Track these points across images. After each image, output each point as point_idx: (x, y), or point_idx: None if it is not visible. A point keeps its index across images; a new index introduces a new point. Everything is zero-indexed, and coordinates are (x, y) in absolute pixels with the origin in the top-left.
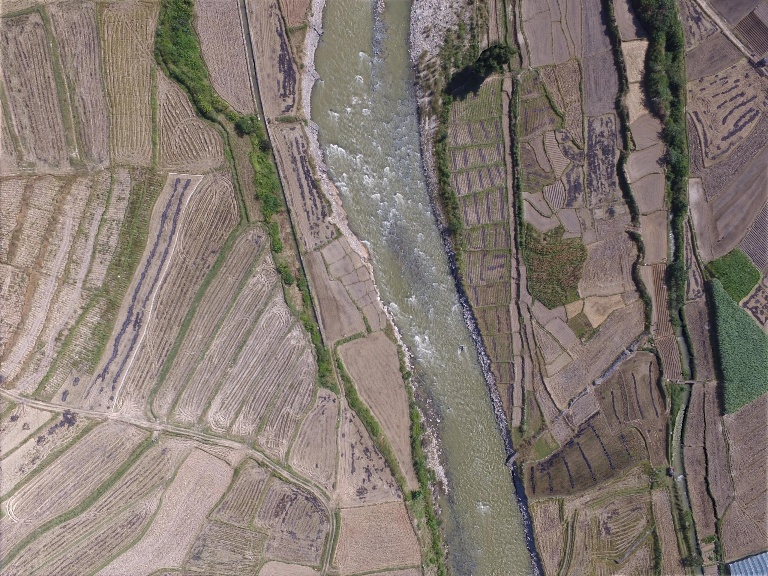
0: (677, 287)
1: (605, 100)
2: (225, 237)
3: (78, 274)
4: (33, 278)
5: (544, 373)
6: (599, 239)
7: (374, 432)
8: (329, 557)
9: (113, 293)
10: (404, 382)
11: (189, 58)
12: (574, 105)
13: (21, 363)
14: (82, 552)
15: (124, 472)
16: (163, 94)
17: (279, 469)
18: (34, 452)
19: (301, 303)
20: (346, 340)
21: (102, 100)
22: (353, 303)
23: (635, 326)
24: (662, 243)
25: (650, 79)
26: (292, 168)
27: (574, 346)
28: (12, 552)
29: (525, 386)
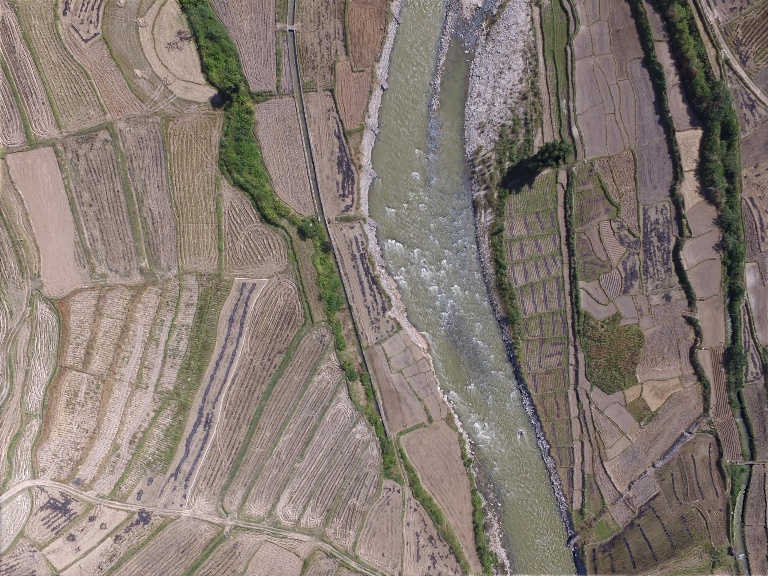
0: (736, 371)
1: (660, 188)
2: (290, 338)
3: (150, 379)
4: (107, 385)
5: (604, 457)
6: (656, 324)
7: (439, 521)
8: None
9: (184, 396)
10: (466, 469)
11: (252, 167)
12: (629, 194)
13: (97, 466)
14: None
15: (198, 567)
16: (228, 202)
17: (347, 559)
18: (111, 550)
19: (364, 397)
20: (408, 431)
21: (169, 210)
22: (414, 394)
23: (694, 408)
24: (719, 327)
25: (706, 168)
26: (352, 266)
27: (633, 430)
28: None
29: (585, 470)
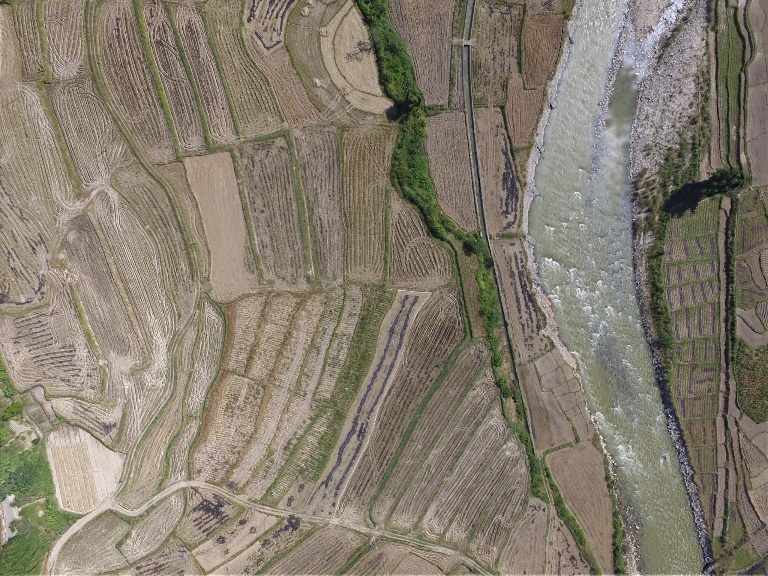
0: None
1: None
2: (449, 352)
3: (308, 386)
4: (268, 390)
5: (749, 486)
6: None
7: (582, 542)
8: None
9: (340, 404)
10: (609, 491)
11: (424, 180)
12: None
13: (252, 470)
14: None
15: (342, 575)
16: (396, 214)
17: (489, 575)
18: (259, 554)
19: (516, 414)
20: (555, 450)
21: (338, 220)
22: (563, 414)
23: None
24: None
25: None
26: (510, 282)
27: None
28: None
29: (729, 498)
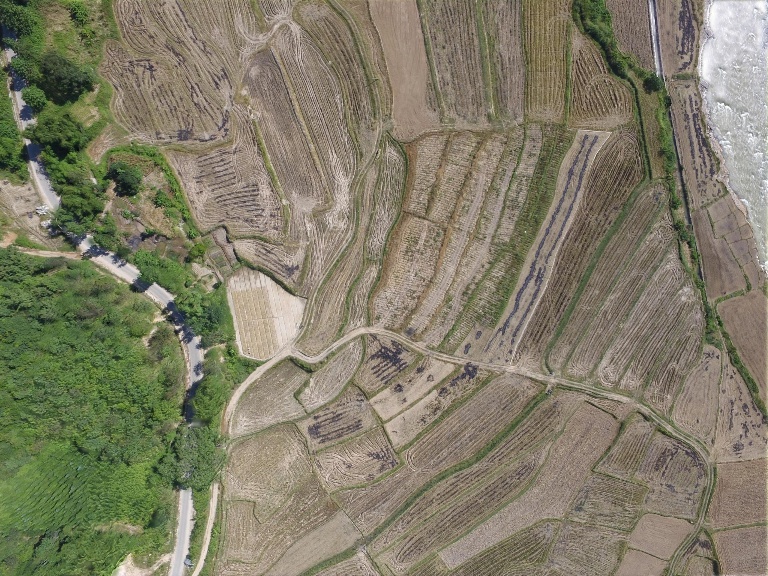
0: None
1: None
2: (628, 193)
3: (487, 229)
4: (448, 233)
5: None
6: None
7: (756, 388)
8: (705, 511)
9: (519, 248)
10: None
11: (607, 14)
12: None
13: (430, 316)
14: (472, 501)
15: (518, 424)
16: (576, 51)
17: (664, 423)
18: (436, 403)
19: (690, 260)
20: (727, 298)
21: (519, 57)
22: (736, 261)
23: None
24: None
25: None
26: (684, 126)
27: None
28: (409, 500)
29: None
